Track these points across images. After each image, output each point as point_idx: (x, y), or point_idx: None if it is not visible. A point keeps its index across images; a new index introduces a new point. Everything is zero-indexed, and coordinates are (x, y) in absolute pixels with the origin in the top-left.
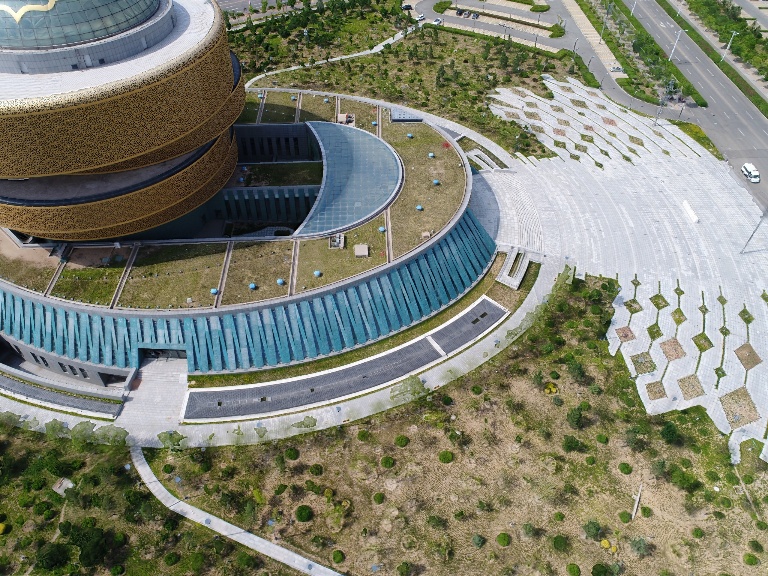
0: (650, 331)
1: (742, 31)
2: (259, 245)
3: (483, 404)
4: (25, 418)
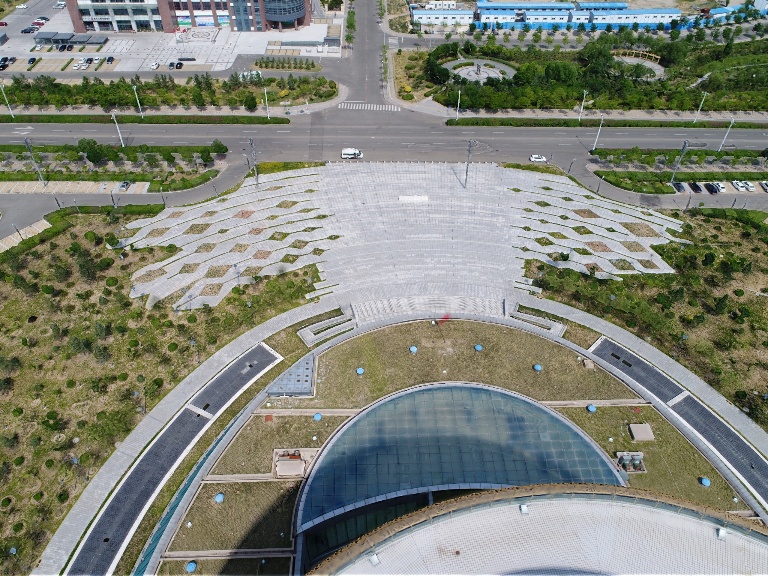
0: (583, 254)
1: (110, 87)
2: None
3: (728, 369)
4: None
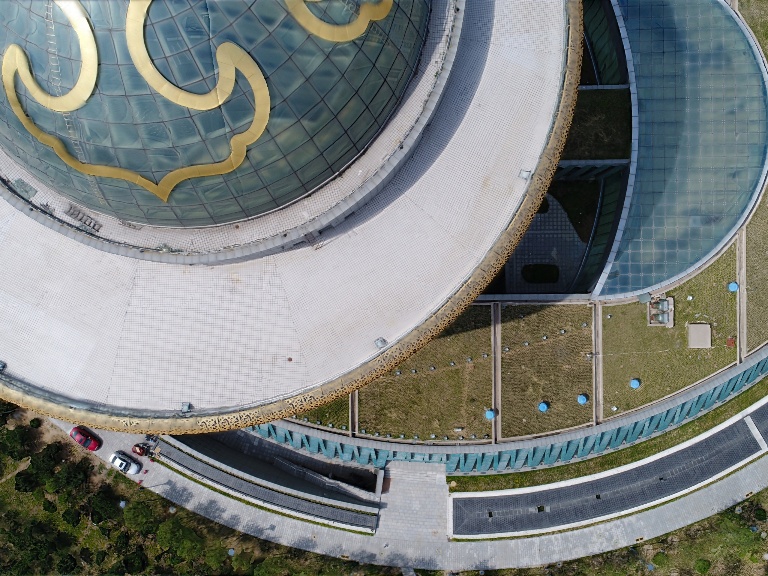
0: None
1: None
2: (539, 313)
3: None
4: (272, 530)
